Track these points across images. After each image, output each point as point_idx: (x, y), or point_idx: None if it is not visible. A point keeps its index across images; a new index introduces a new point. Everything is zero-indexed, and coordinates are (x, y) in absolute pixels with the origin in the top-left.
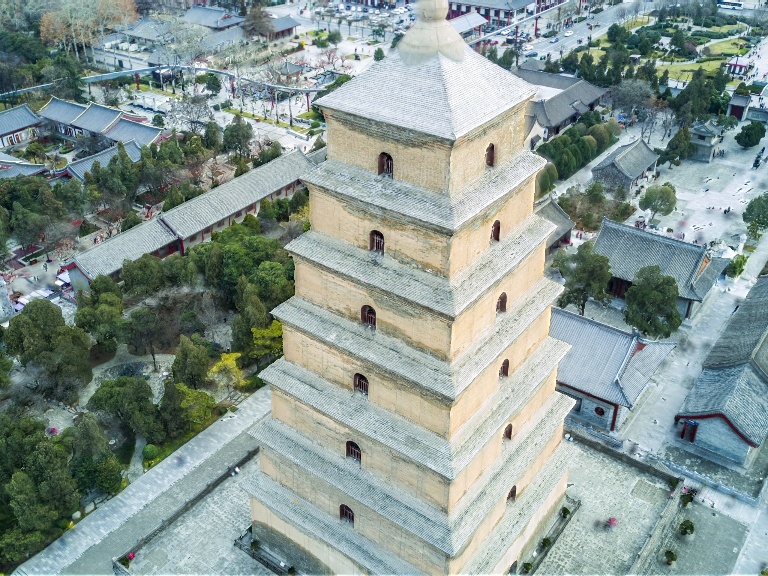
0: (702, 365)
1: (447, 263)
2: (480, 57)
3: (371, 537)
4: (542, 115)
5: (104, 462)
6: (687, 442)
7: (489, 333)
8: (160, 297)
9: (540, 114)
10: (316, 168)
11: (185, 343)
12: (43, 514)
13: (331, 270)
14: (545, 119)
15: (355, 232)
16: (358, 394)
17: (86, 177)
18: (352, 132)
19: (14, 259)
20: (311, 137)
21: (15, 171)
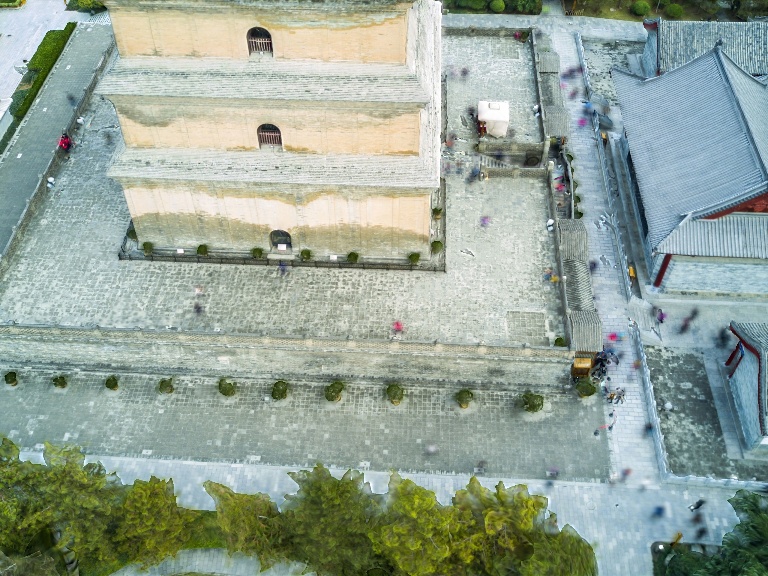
0: None
1: None
2: None
3: None
4: None
5: None
6: (725, 372)
7: None
8: None
9: None
10: None
11: None
12: None
13: None
14: None
15: None
16: None
17: None
18: None
19: None
20: None
21: None
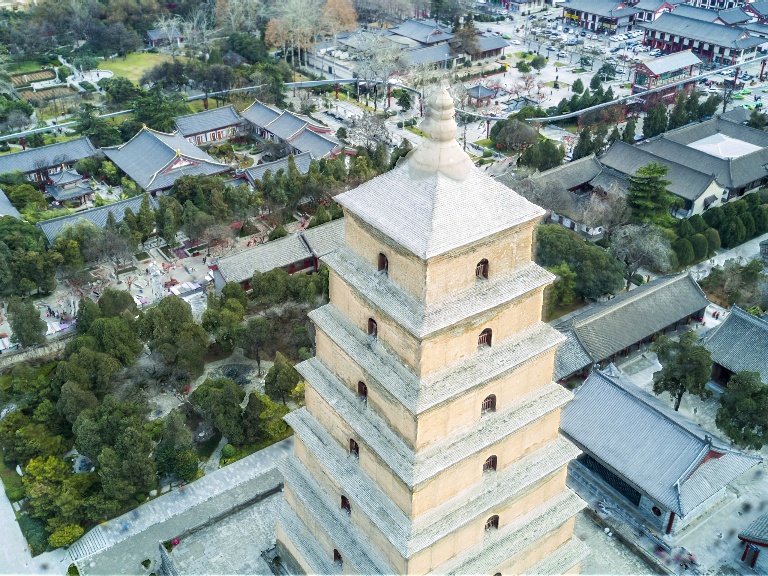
0: None
1: (418, 364)
2: (487, 177)
3: None
4: (725, 174)
5: (183, 453)
6: (747, 566)
7: (469, 430)
8: (280, 309)
9: (723, 172)
10: (334, 253)
11: (279, 359)
12: (123, 487)
13: (337, 344)
14: (727, 179)
15: (359, 315)
16: (353, 456)
17: (256, 183)
18: (361, 229)
19: (182, 249)
20: (479, 166)
21: (203, 168)
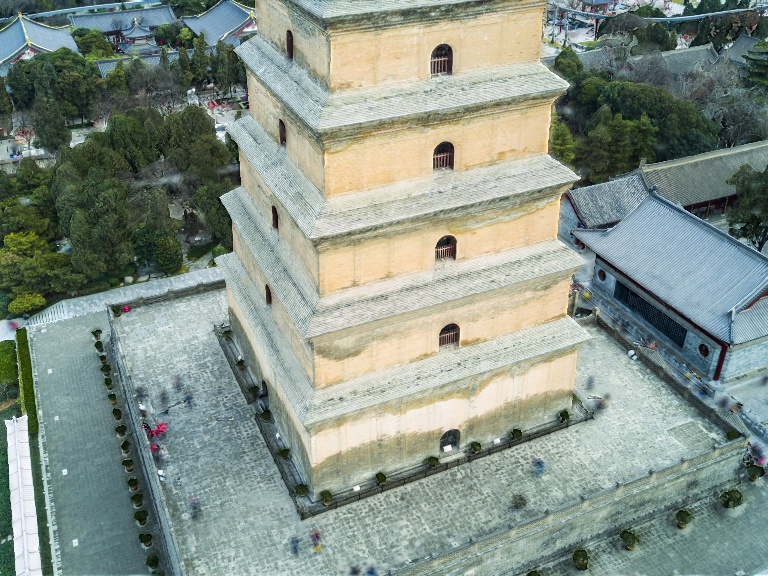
0: None
1: None
2: None
3: (280, 325)
4: None
5: (163, 238)
6: None
7: (411, 87)
8: None
9: None
10: None
11: None
12: (92, 261)
13: None
14: None
15: None
16: (282, 148)
17: None
18: None
19: (238, 102)
20: None
21: None
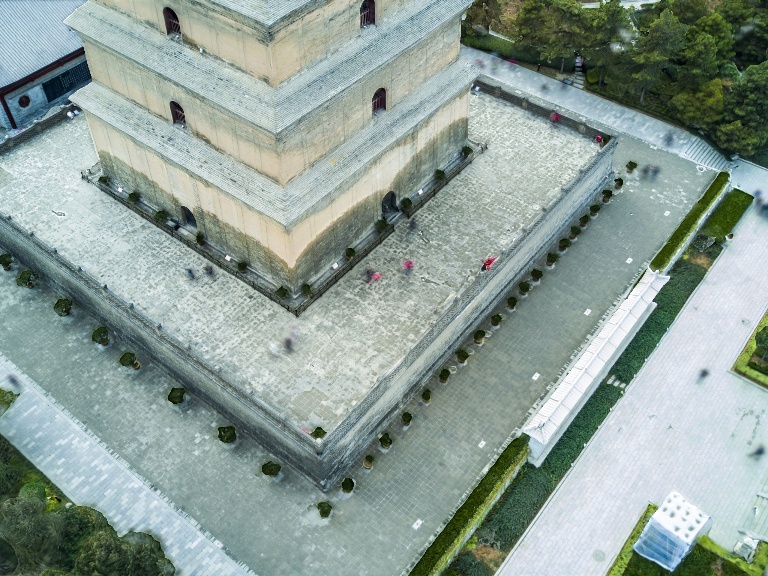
0: None
1: None
2: None
3: None
4: None
5: (87, 517)
6: None
7: None
8: None
9: None
10: None
11: None
12: None
13: None
14: None
15: None
16: None
17: None
18: None
19: None
20: None
21: None
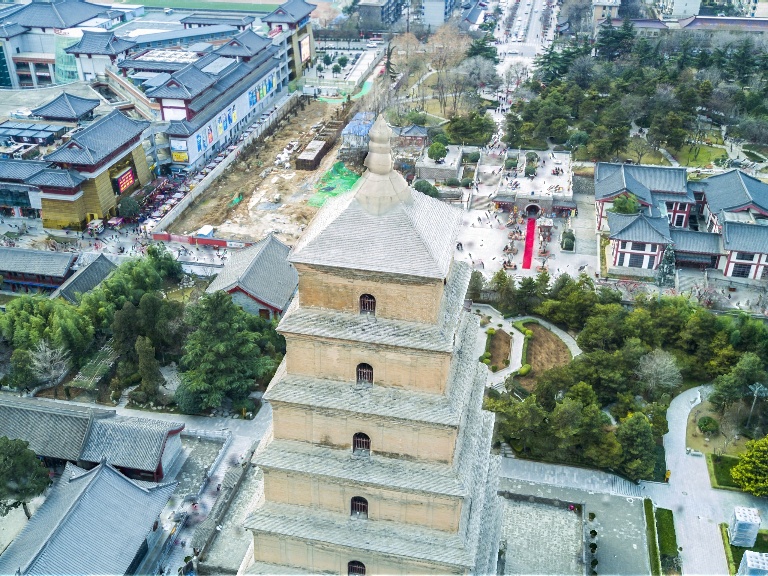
0: (76, 459)
1: None
2: None
3: None
4: None
5: None
6: (164, 481)
7: None
8: None
9: None
10: None
11: None
12: None
13: None
14: None
15: None
16: None
17: None
18: None
19: None
20: None
21: None
